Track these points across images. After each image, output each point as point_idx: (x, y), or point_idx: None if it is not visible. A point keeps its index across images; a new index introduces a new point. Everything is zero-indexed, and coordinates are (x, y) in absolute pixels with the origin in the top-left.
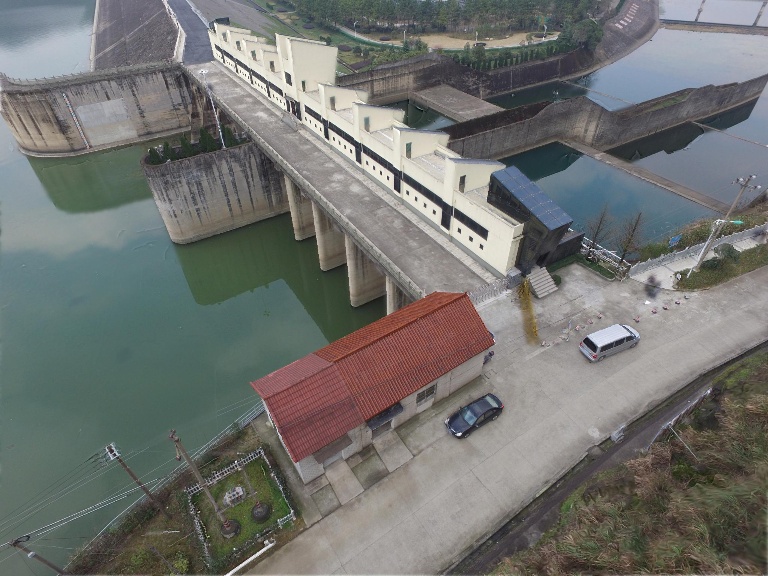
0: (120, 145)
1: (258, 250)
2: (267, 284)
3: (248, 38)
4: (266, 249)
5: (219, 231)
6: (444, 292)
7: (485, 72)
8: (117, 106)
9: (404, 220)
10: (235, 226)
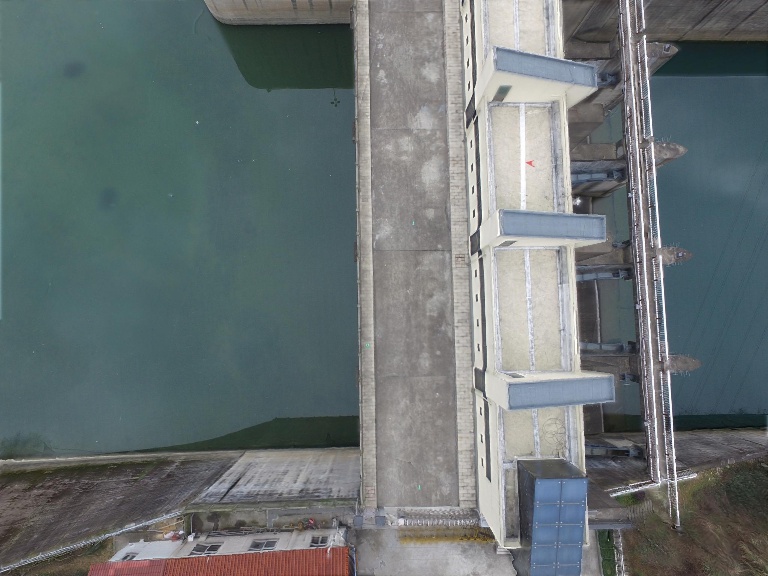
0: None
1: (330, 54)
2: (336, 89)
3: None
4: (342, 56)
5: (273, 21)
6: (347, 572)
7: None
8: None
9: (448, 301)
10: (299, 21)
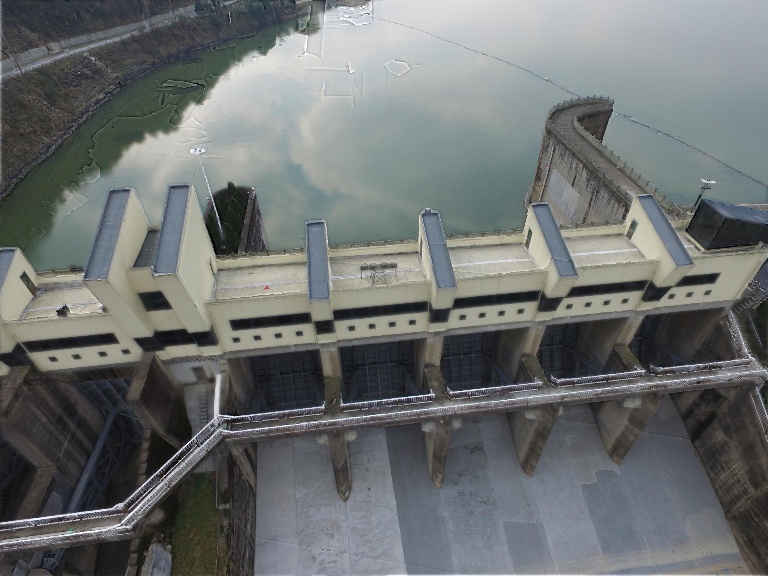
0: None
1: None
2: None
3: (543, 243)
4: None
5: None
6: None
7: None
8: (573, 199)
9: None
10: None
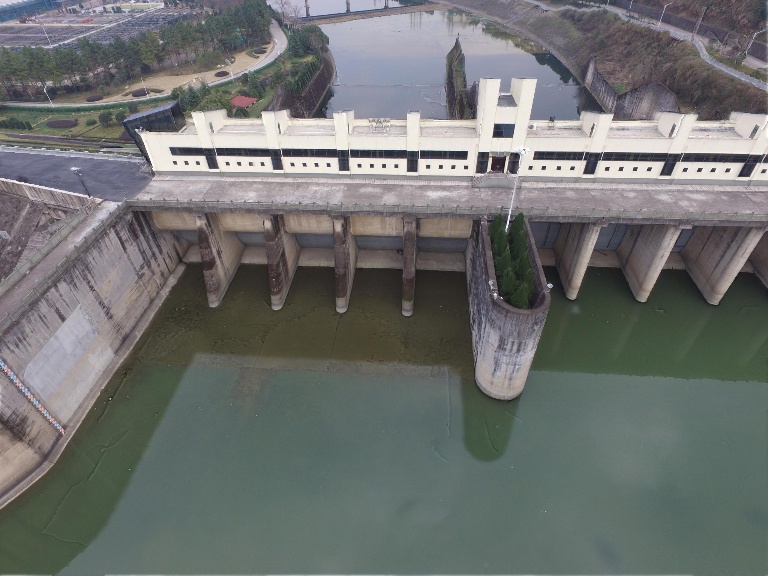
0: (103, 388)
1: None
2: None
3: (282, 115)
4: None
5: None
6: None
7: (300, 95)
8: (76, 324)
9: None
10: None
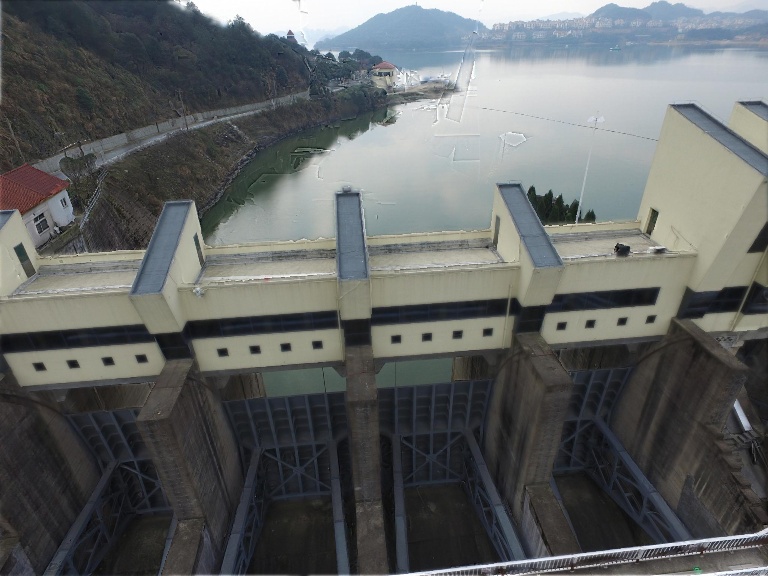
0: None
1: None
2: None
3: None
4: None
5: None
6: None
7: None
8: None
9: None
10: None
